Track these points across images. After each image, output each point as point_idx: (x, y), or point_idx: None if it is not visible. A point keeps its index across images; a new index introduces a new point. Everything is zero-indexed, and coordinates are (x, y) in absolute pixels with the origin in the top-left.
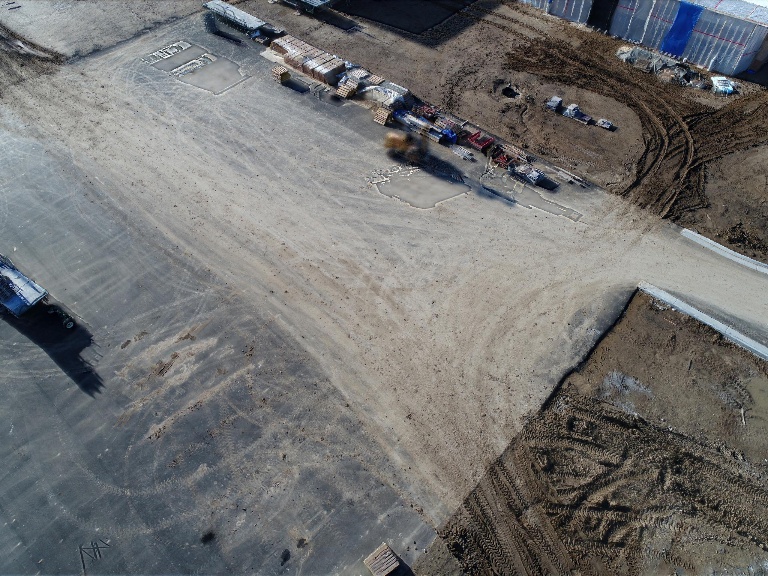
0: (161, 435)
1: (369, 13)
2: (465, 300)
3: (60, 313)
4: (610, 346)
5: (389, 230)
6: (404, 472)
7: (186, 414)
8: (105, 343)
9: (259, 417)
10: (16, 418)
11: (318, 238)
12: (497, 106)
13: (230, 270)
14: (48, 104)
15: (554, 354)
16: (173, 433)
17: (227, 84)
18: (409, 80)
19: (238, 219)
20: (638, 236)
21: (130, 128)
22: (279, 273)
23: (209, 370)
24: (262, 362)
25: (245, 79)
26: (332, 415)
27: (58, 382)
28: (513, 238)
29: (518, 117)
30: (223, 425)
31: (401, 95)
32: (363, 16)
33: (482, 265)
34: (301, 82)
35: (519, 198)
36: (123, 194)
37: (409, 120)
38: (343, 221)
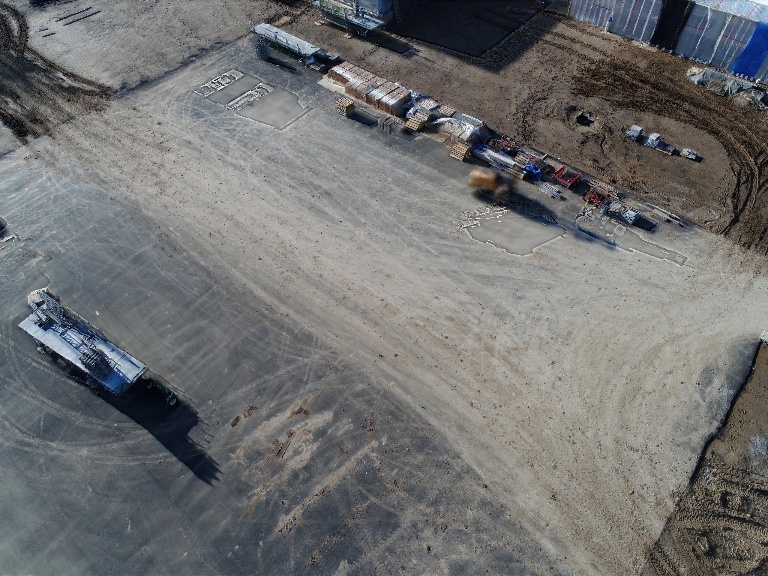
0: (292, 527)
1: (422, 34)
2: (586, 359)
3: (161, 388)
4: (746, 408)
5: (490, 281)
6: (560, 563)
7: (315, 502)
8: (213, 421)
9: (394, 503)
10: (132, 512)
11: (418, 292)
12: (574, 136)
13: (332, 332)
14: (104, 145)
15: (690, 419)
16: (305, 525)
17: (289, 118)
18: (478, 109)
19: (329, 272)
20: (749, 280)
21: (196, 170)
22: (384, 334)
23: (330, 449)
24: (385, 438)
25: (307, 111)
26: (471, 498)
27: (170, 468)
28: (621, 286)
29: (598, 148)
30: (357, 514)
31: (476, 128)
32: (417, 38)
33: (595, 318)
34: (366, 114)
35: (618, 240)
36: (202, 247)
37: (489, 155)
38: (440, 272)
